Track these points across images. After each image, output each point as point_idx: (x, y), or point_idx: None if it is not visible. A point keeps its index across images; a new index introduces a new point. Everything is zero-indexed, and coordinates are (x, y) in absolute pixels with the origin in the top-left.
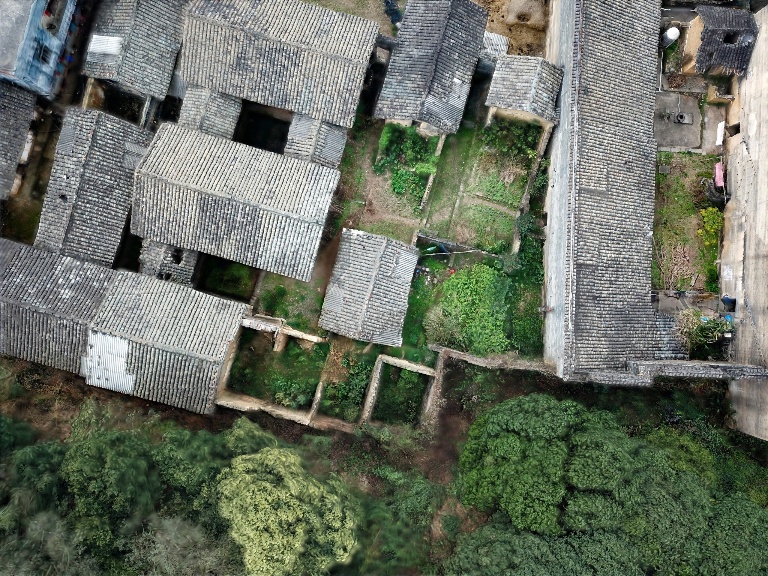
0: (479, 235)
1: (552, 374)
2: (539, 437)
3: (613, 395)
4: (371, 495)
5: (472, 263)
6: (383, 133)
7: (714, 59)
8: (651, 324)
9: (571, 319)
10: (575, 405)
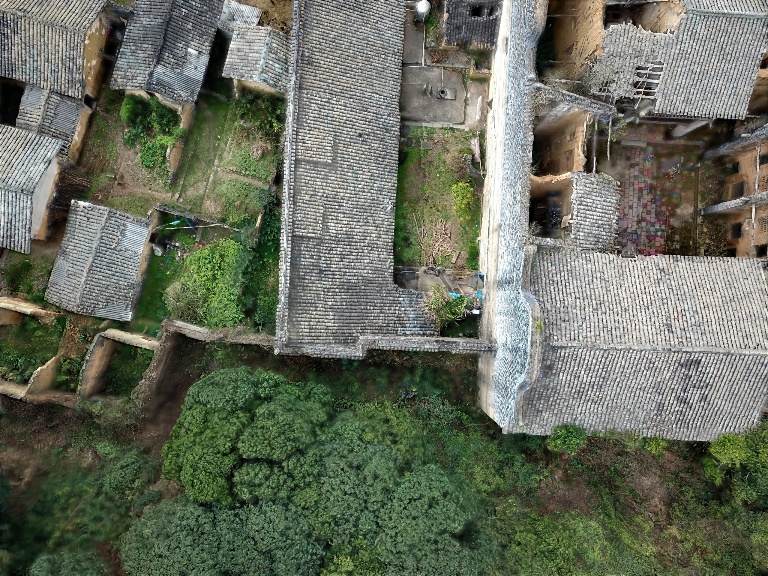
0: (227, 210)
1: (272, 348)
2: (222, 409)
3: (361, 372)
4: (86, 471)
5: (220, 238)
6: (122, 105)
7: (464, 32)
8: (392, 300)
9: (284, 292)
10: (276, 378)
